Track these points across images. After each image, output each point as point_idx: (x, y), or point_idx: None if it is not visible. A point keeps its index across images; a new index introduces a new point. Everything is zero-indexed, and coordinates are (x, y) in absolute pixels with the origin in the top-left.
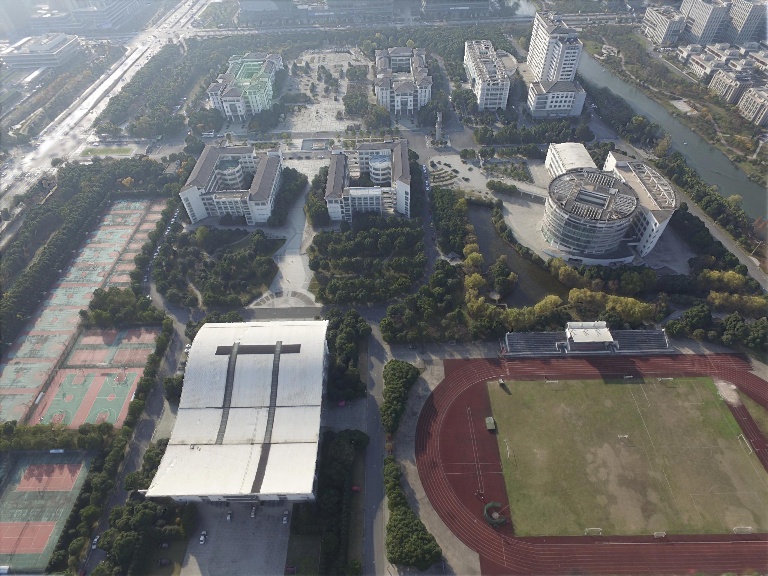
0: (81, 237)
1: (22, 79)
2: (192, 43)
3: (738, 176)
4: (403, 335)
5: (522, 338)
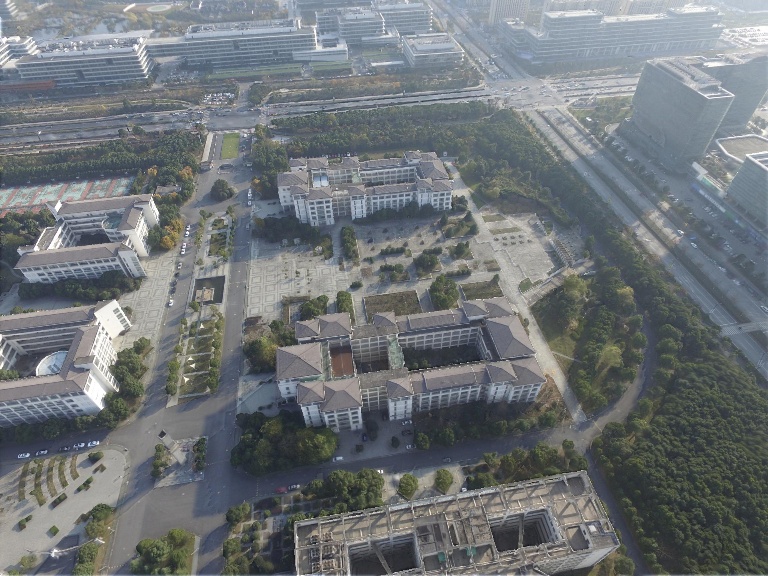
0: (74, 177)
1: (376, 62)
2: (500, 116)
3: None
4: None
5: None
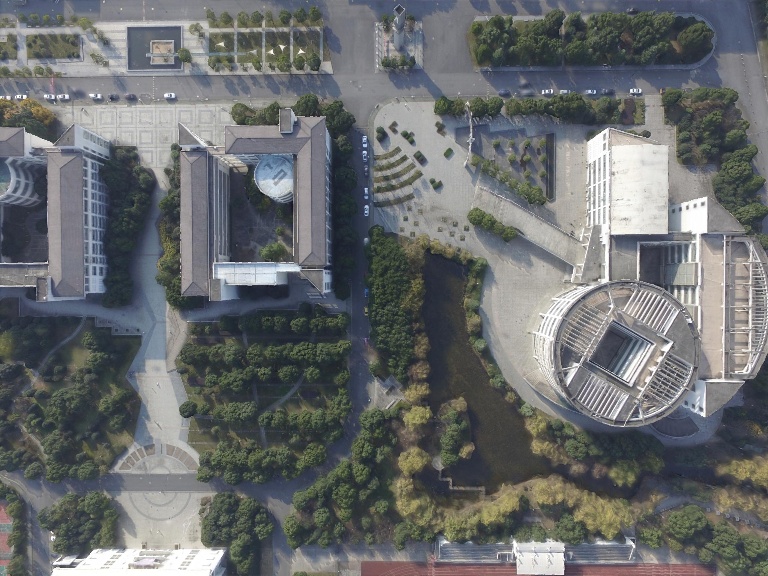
0: None
1: None
2: None
3: None
4: (313, 540)
5: (458, 547)
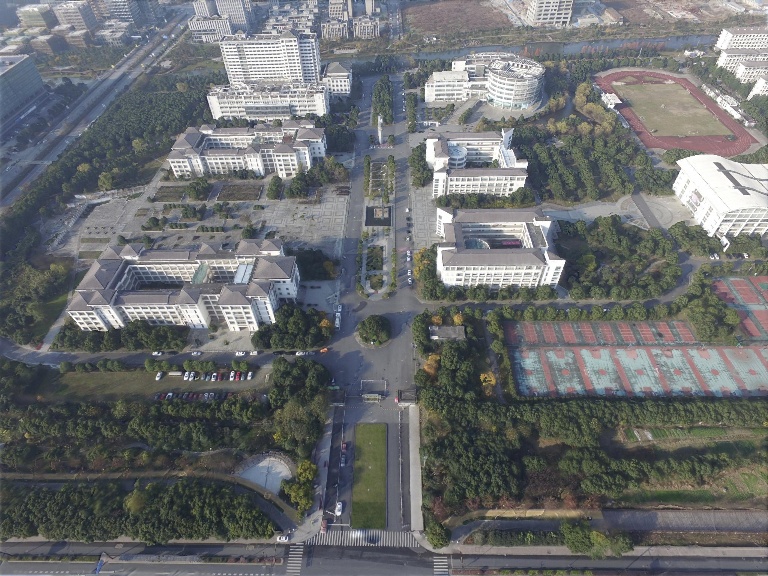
0: None
1: None
2: None
3: (423, 58)
4: None
5: None
